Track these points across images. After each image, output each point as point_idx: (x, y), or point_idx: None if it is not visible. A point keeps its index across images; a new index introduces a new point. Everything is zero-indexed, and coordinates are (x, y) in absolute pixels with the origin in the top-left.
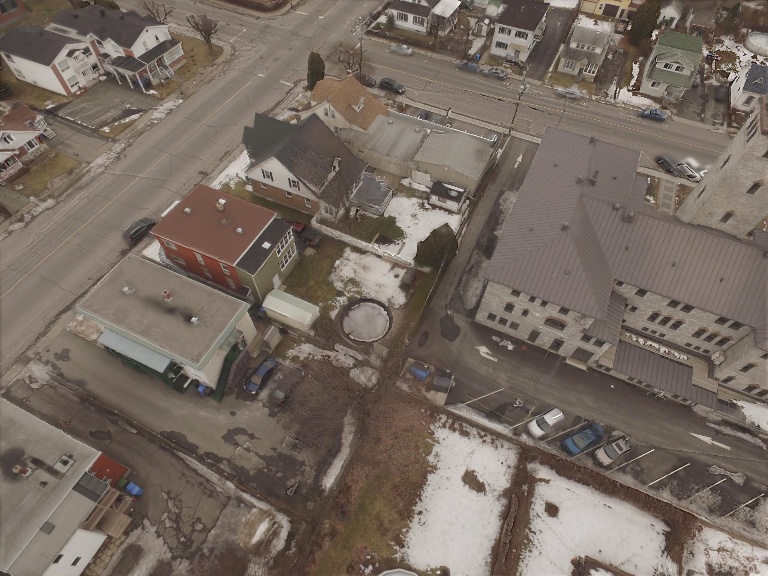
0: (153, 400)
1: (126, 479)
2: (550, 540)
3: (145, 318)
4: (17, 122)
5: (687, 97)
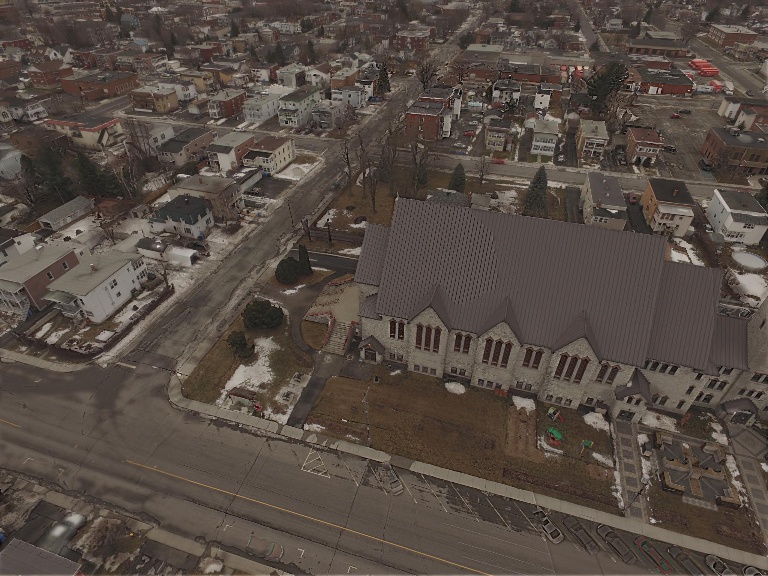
0: None
1: None
2: None
3: None
4: None
5: None
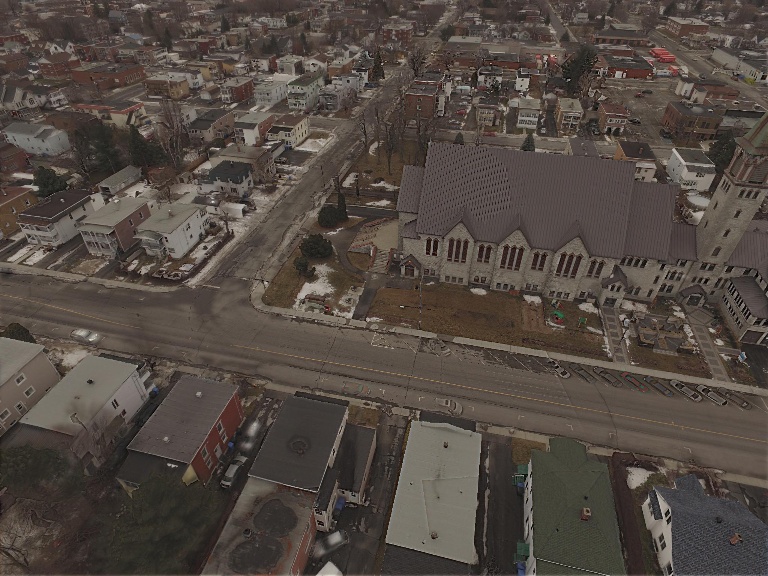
0: None
1: None
2: None
3: None
4: None
5: None
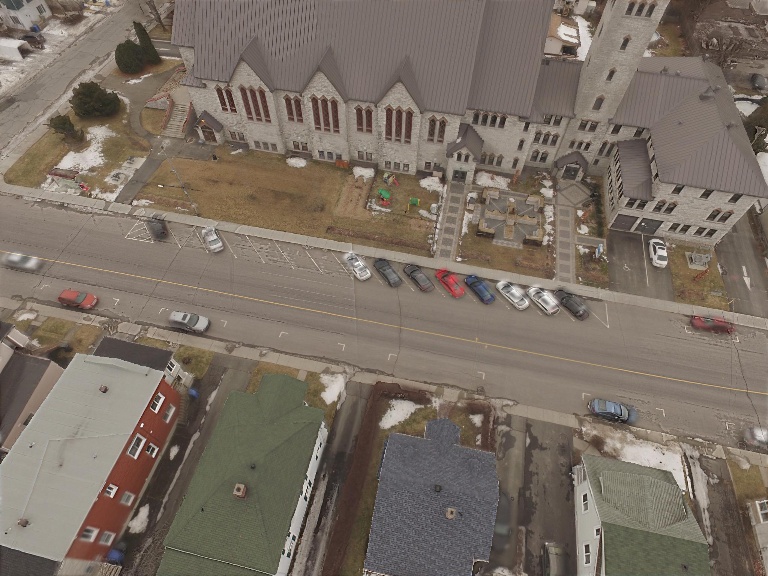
0: None
1: None
2: None
3: None
4: None
5: (560, 498)
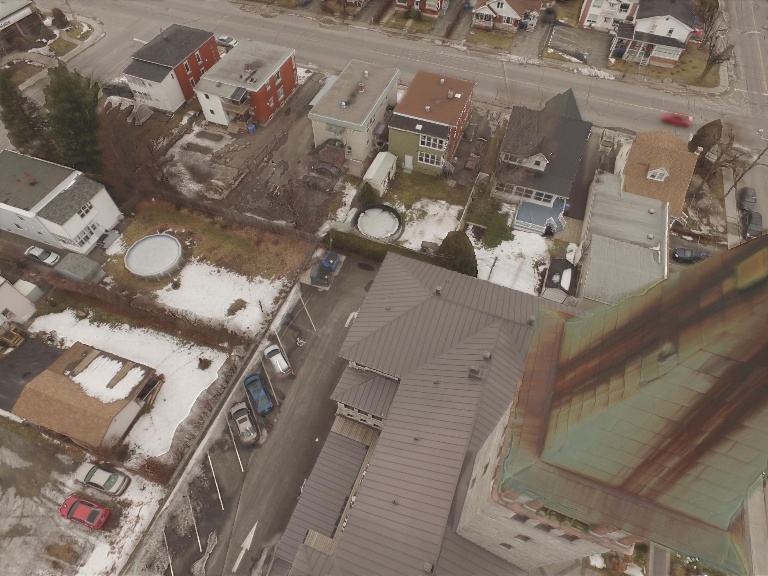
0: (310, 126)
1: (259, 125)
2: (182, 360)
3: (346, 86)
4: (525, 6)
5: None
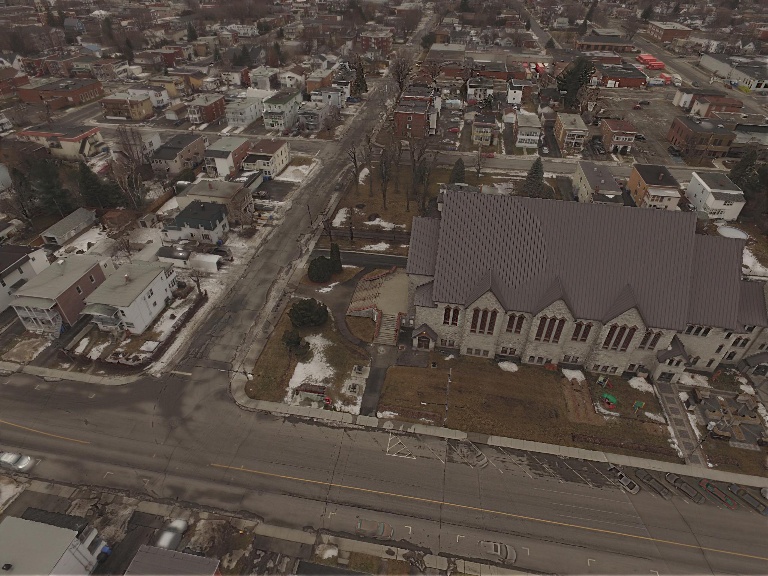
0: None
1: None
2: None
3: None
4: None
5: None
